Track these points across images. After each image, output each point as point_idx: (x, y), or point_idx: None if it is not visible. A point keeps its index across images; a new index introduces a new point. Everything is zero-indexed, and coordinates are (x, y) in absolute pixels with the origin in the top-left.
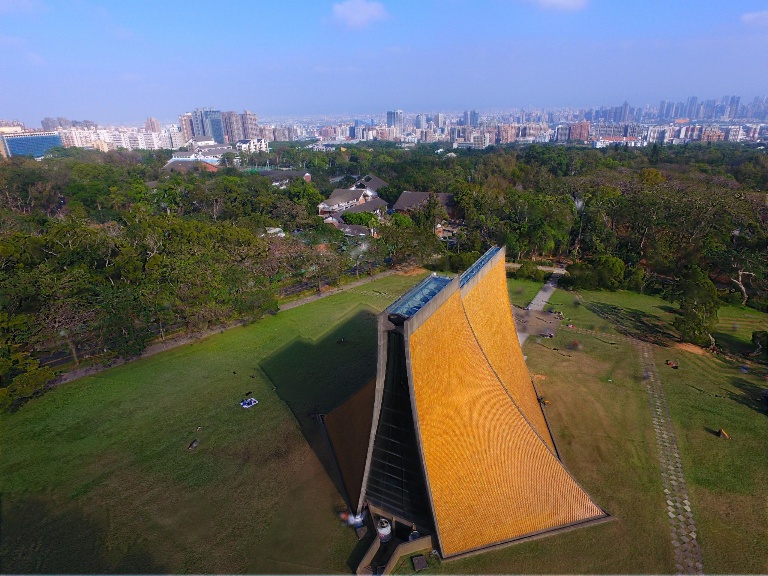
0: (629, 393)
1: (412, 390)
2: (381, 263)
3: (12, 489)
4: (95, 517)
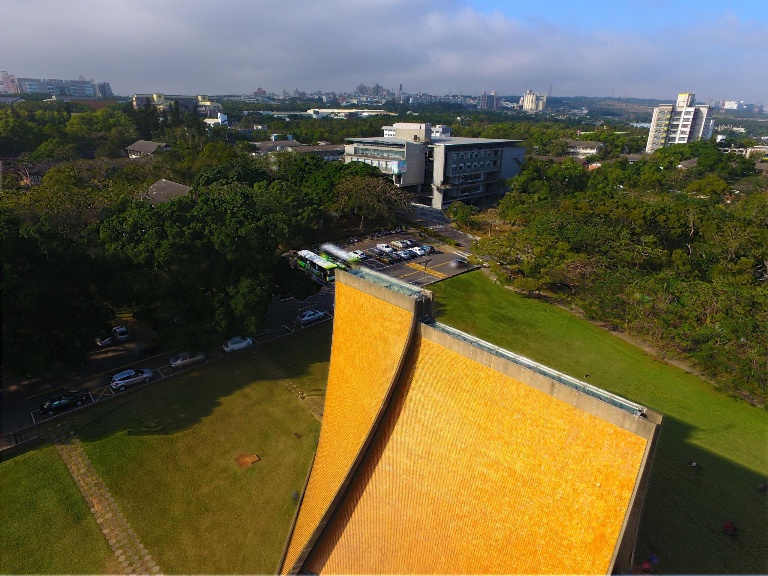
0: None
1: None
2: None
3: None
4: None
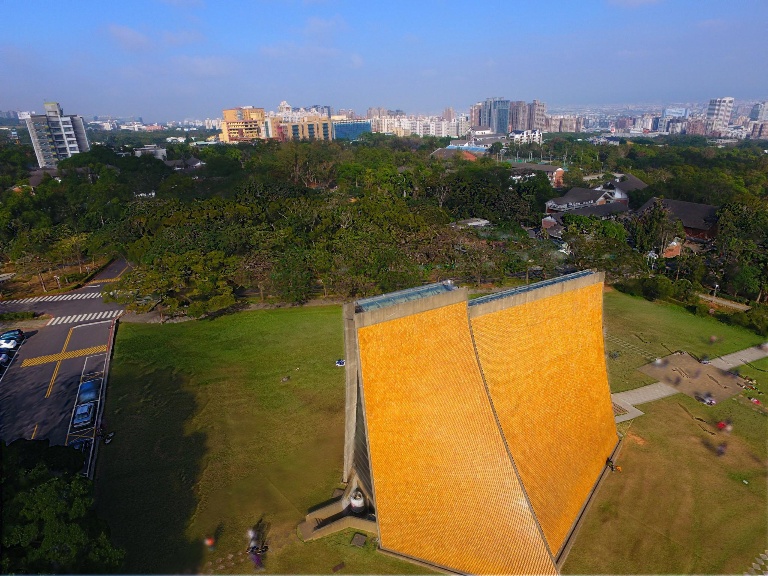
0: (759, 507)
1: (359, 379)
2: (551, 271)
3: (177, 366)
4: (200, 401)
